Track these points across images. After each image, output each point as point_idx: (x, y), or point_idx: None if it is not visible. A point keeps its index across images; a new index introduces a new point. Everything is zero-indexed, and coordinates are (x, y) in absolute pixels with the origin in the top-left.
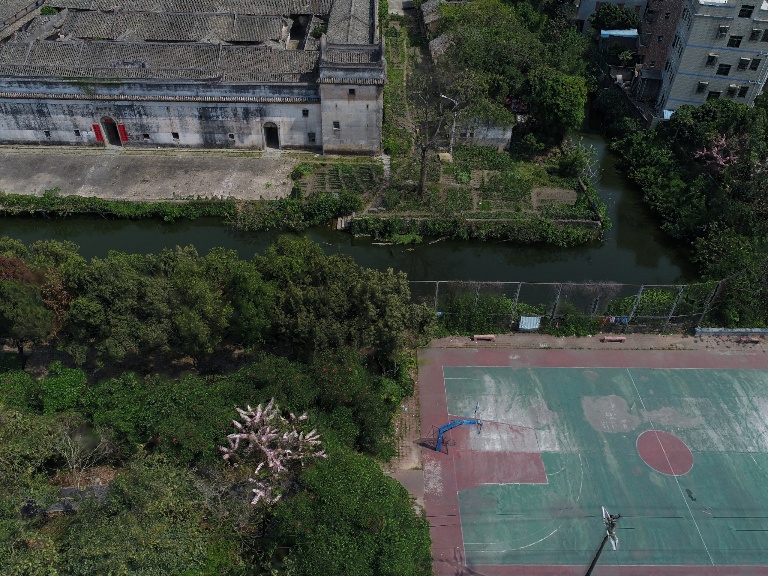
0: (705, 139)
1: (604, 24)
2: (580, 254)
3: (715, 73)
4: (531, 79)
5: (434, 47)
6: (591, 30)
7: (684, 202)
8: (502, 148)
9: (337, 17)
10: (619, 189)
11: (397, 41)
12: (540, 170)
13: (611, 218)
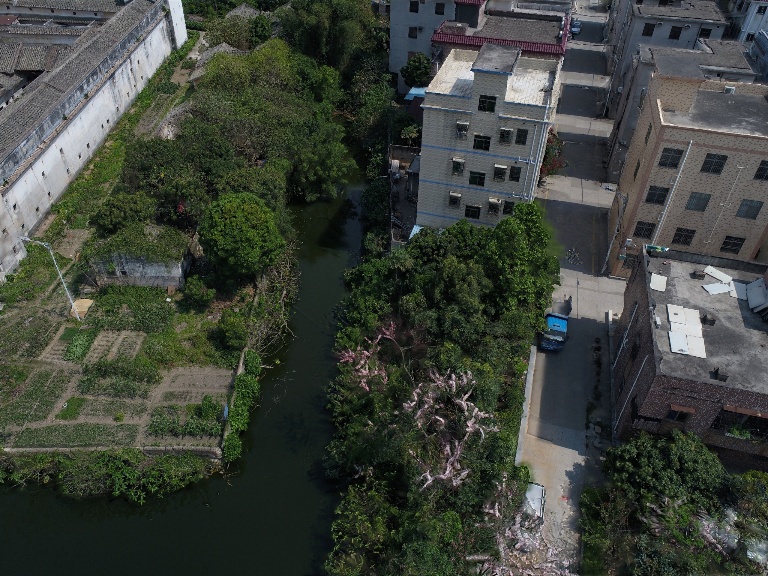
0: (402, 306)
1: (415, 80)
2: (187, 499)
3: (467, 182)
4: (218, 188)
5: (164, 121)
6: (389, 91)
7: (365, 405)
8: (173, 288)
9: (38, 82)
10: (315, 358)
11: (166, 100)
12: (197, 334)
13: (269, 422)
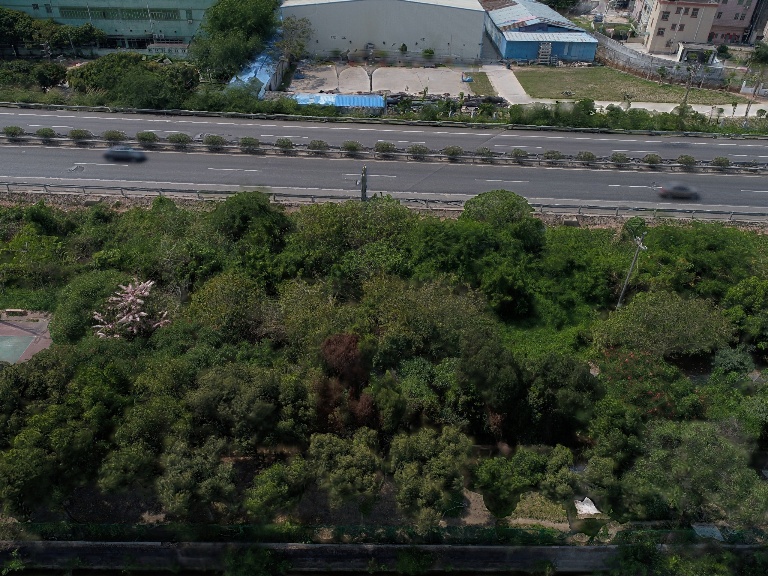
0: None
1: None
2: None
3: None
4: None
5: None
6: None
7: None
8: None
9: None
10: None
11: None
12: None
13: None
